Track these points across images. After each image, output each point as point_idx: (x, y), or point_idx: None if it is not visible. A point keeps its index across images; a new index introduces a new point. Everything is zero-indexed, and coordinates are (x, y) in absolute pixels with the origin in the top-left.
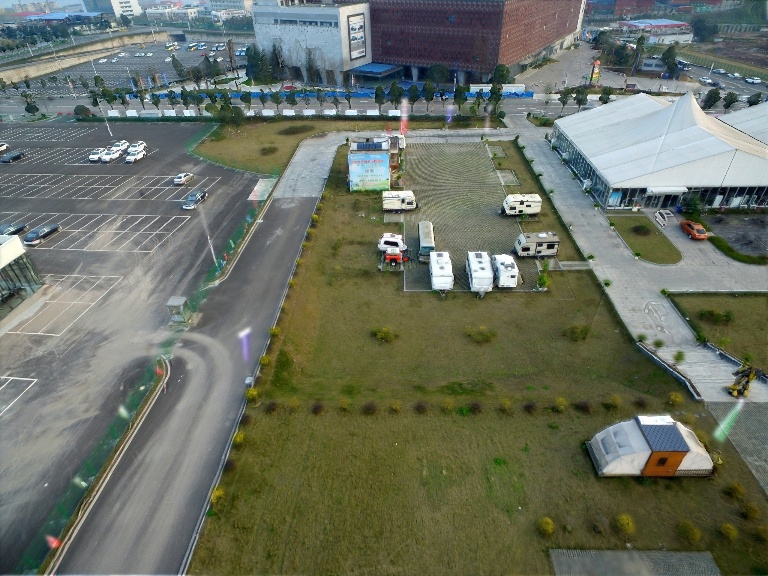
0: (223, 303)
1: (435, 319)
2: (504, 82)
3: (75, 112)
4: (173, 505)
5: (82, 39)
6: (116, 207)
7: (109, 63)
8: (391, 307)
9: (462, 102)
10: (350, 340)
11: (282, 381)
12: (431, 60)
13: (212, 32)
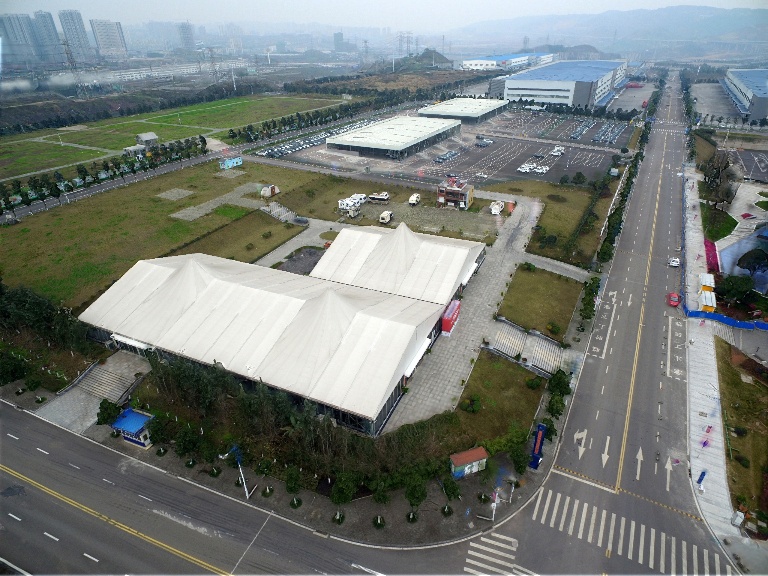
0: None
1: None
2: (727, 296)
3: None
4: (314, 170)
5: None
6: None
7: None
8: None
9: None
10: None
11: None
12: None
13: None
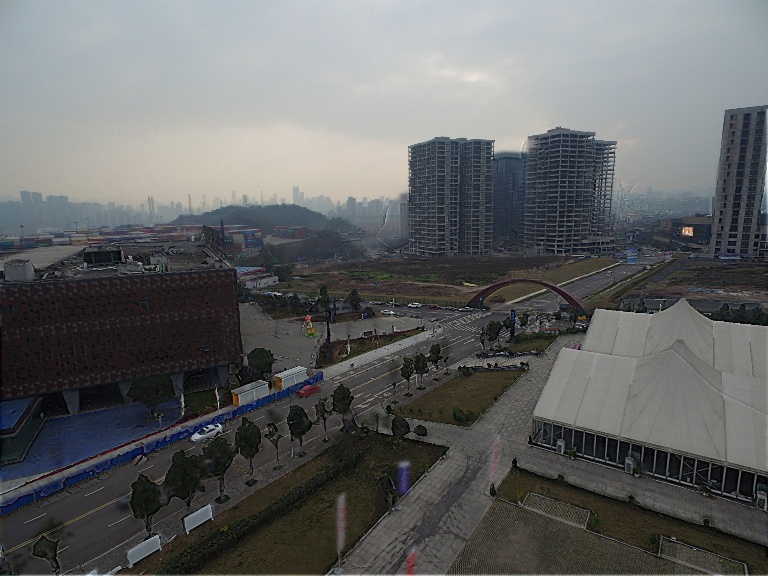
0: None
1: None
2: (270, 371)
3: None
4: None
5: None
6: None
7: None
8: None
9: (305, 431)
10: None
11: None
12: (111, 370)
13: None
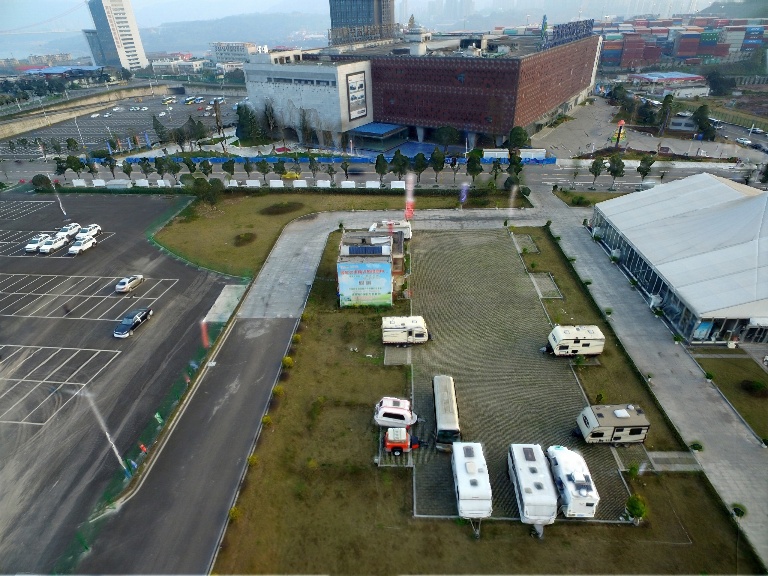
0: (116, 561)
1: None
2: (521, 146)
3: (33, 183)
4: None
5: (78, 93)
6: (28, 331)
7: (101, 118)
8: (393, 555)
9: (476, 173)
10: None
11: None
12: (438, 120)
13: (212, 85)
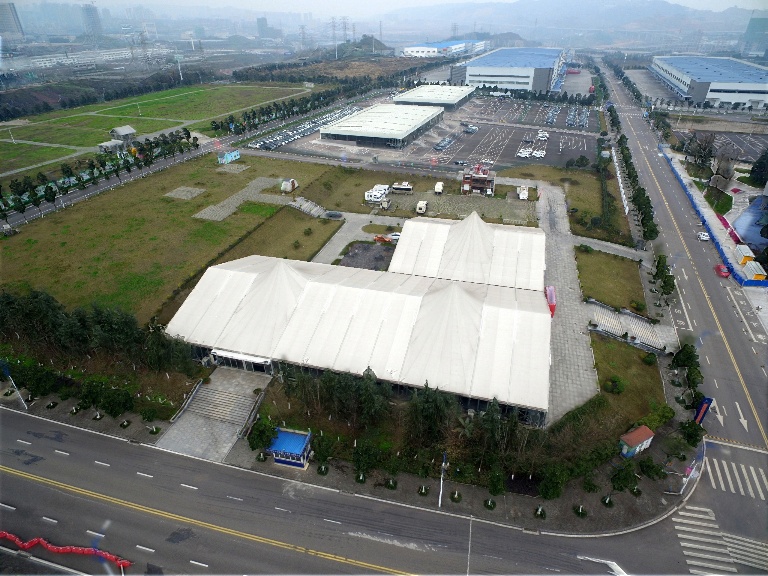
0: None
1: (361, 191)
2: None
3: None
4: None
5: None
6: None
7: None
8: None
9: None
10: None
11: (345, 171)
12: None
13: None
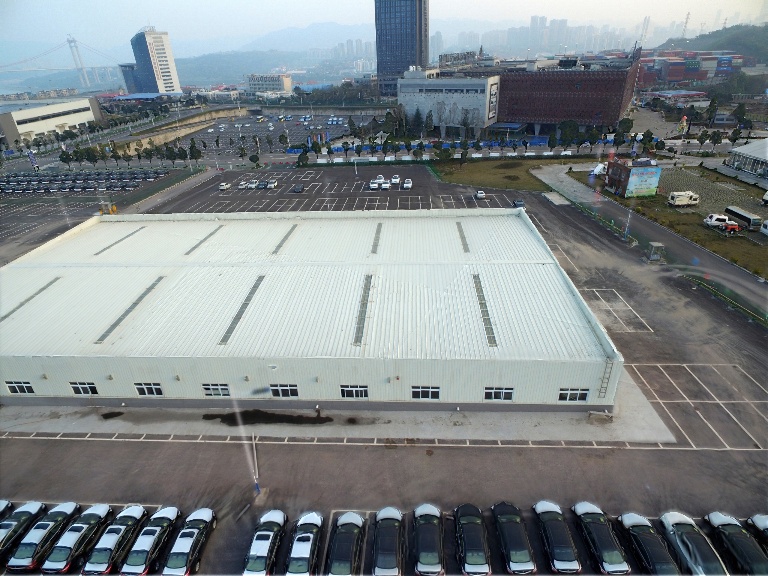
0: None
1: None
2: None
3: (300, 159)
4: None
5: (181, 114)
6: None
7: (218, 132)
8: (766, 254)
9: (621, 144)
10: (767, 270)
11: None
12: (555, 118)
13: (291, 107)
